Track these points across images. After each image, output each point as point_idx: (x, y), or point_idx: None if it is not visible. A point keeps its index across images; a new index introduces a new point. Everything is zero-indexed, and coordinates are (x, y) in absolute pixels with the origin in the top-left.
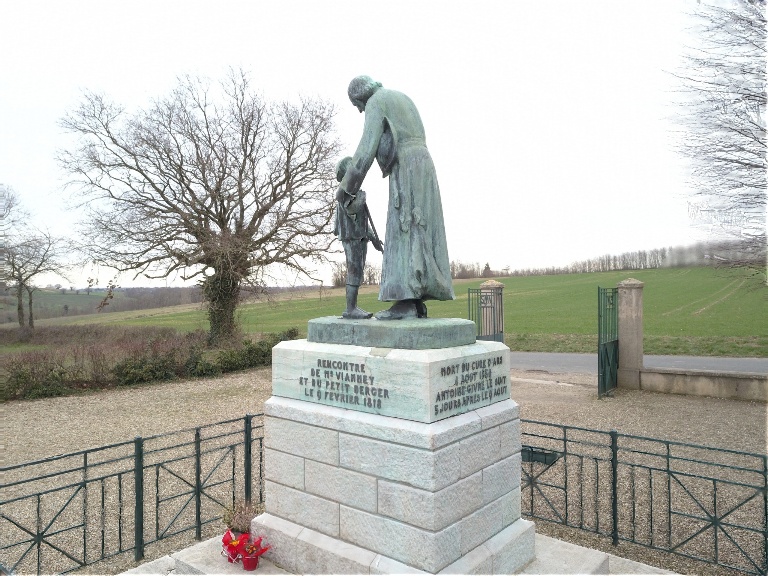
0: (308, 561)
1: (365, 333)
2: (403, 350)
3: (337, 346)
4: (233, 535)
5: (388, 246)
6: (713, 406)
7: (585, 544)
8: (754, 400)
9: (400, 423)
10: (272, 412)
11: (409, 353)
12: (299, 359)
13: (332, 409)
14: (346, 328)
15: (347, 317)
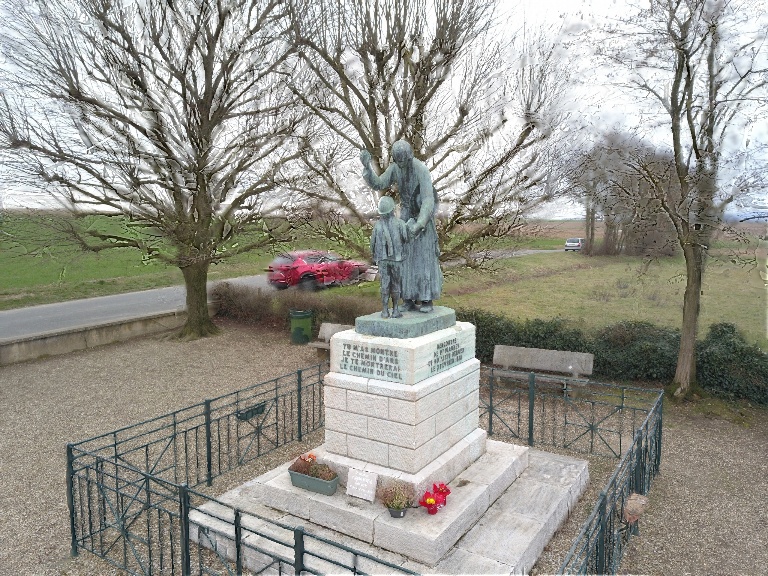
0: (447, 473)
1: (442, 321)
2: (461, 324)
3: (441, 333)
4: (388, 522)
5: (435, 266)
6: (9, 376)
7: (298, 448)
8: (17, 362)
9: (469, 362)
10: (420, 396)
11: (467, 325)
12: (428, 350)
13: (445, 373)
14: (434, 321)
15: (399, 316)
